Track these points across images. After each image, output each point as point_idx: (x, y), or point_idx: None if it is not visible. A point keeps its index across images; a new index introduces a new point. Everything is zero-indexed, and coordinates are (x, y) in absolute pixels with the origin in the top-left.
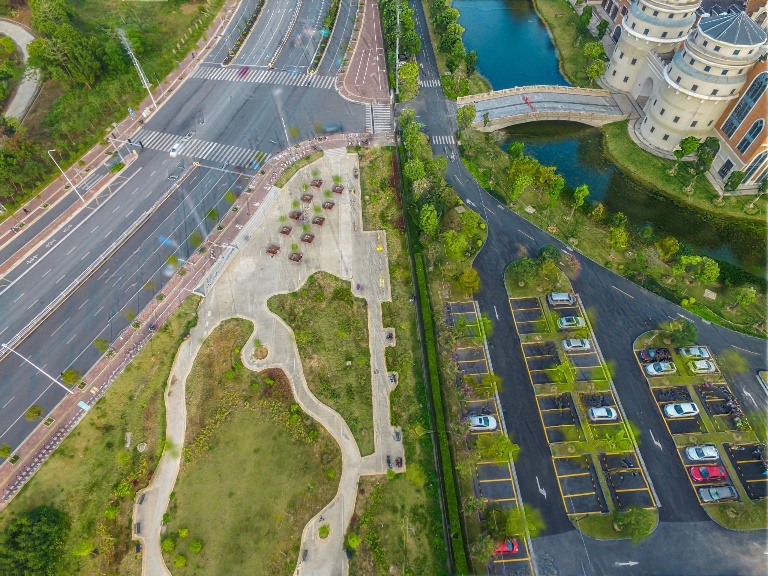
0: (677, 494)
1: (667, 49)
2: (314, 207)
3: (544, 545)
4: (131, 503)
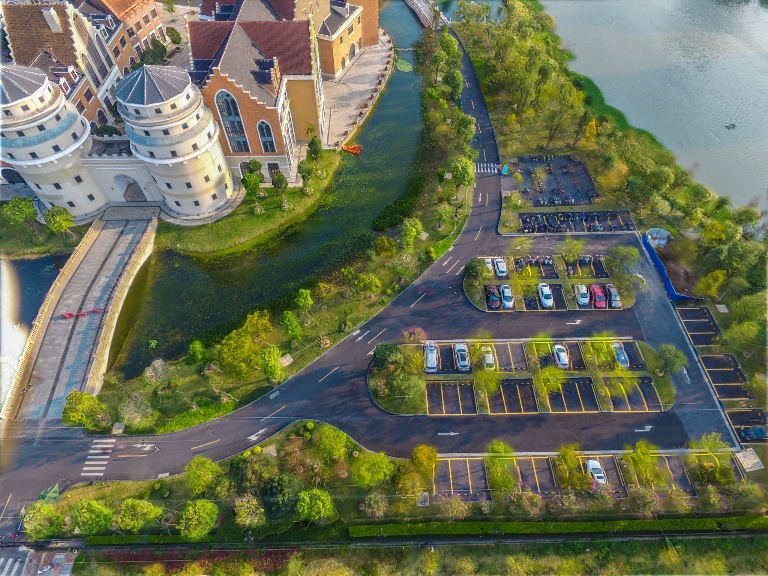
0: (618, 323)
1: (89, 144)
2: None
3: (696, 438)
4: None
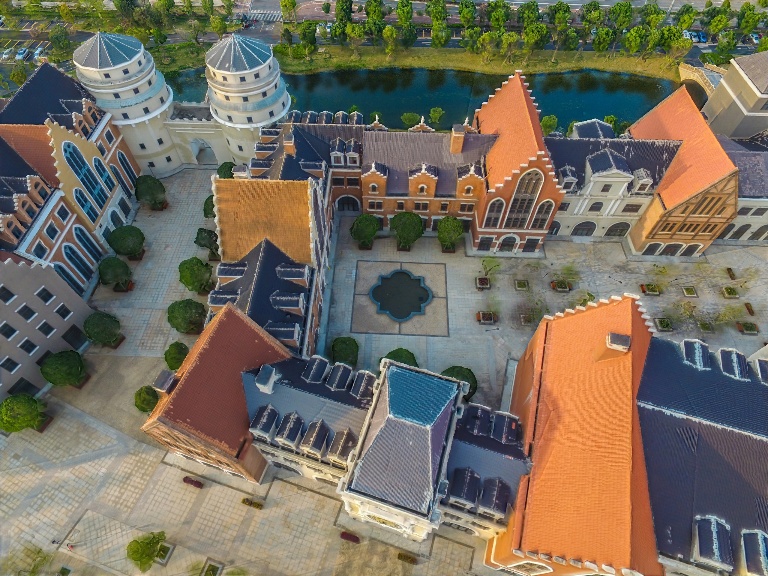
0: None
1: None
2: None
3: None
4: None
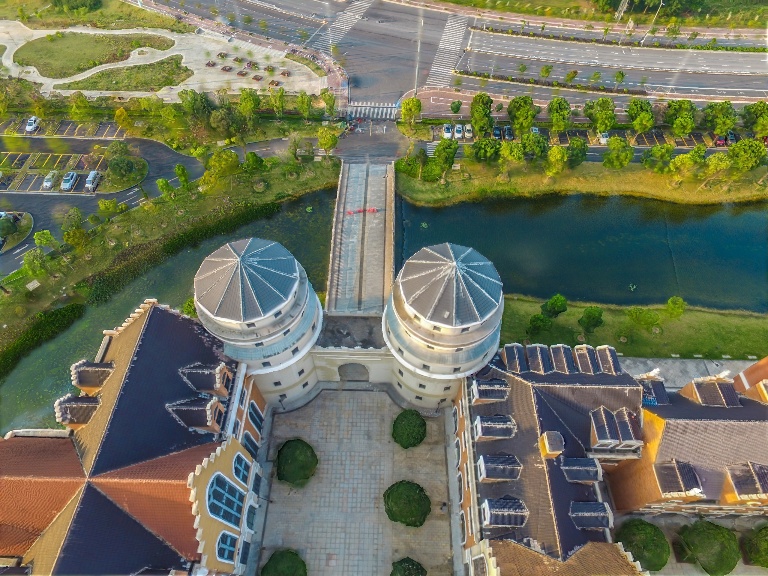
0: None
1: None
2: (259, 72)
3: None
4: (86, 24)
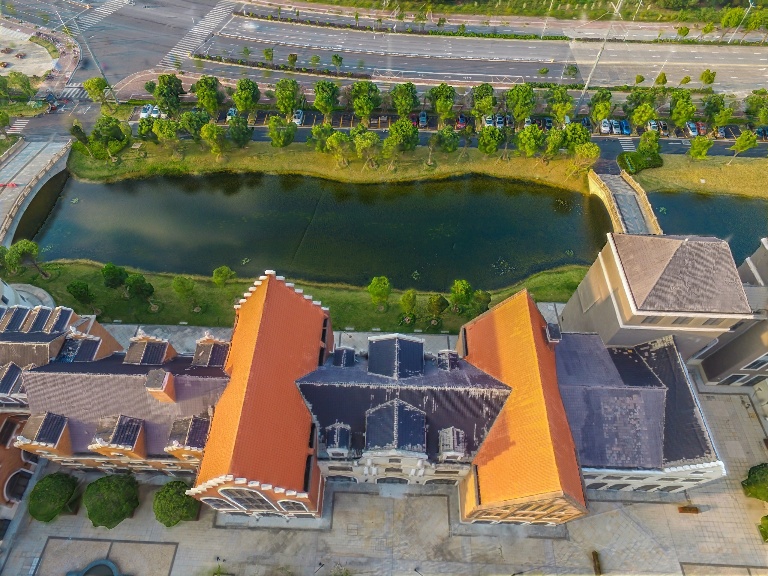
0: None
1: None
2: None
3: None
4: None
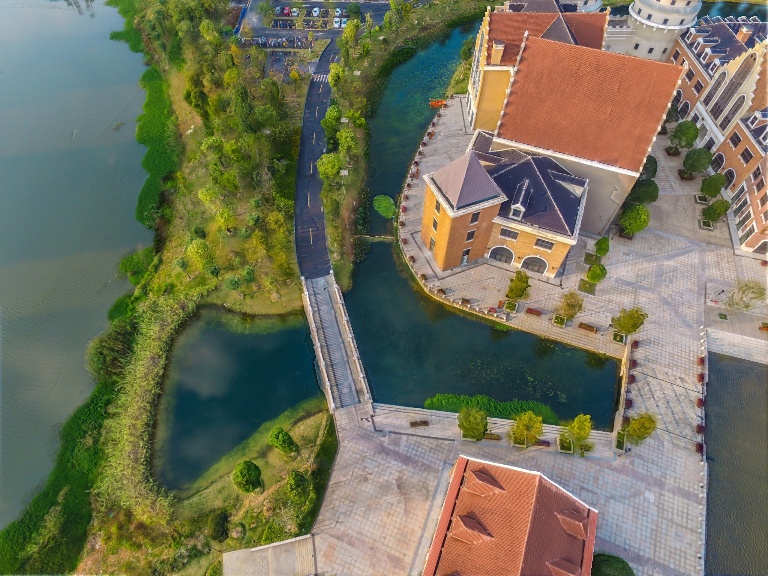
0: (282, 5)
1: None
2: None
3: None
4: None
